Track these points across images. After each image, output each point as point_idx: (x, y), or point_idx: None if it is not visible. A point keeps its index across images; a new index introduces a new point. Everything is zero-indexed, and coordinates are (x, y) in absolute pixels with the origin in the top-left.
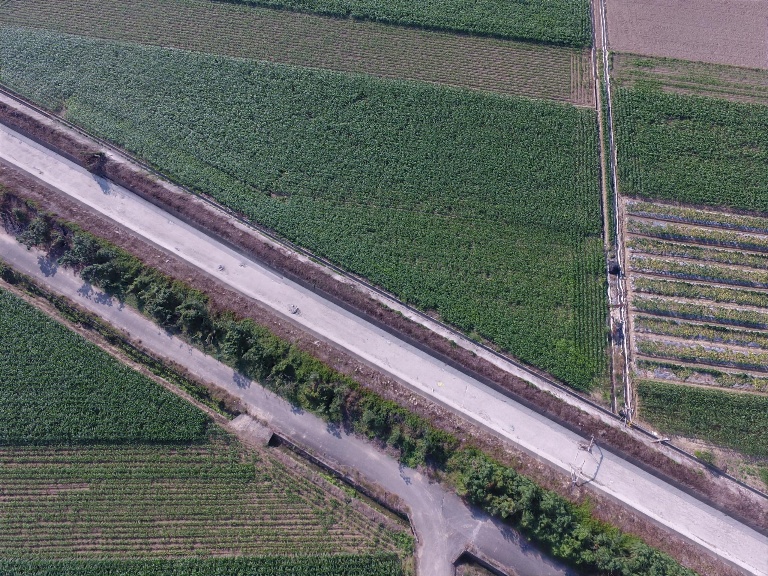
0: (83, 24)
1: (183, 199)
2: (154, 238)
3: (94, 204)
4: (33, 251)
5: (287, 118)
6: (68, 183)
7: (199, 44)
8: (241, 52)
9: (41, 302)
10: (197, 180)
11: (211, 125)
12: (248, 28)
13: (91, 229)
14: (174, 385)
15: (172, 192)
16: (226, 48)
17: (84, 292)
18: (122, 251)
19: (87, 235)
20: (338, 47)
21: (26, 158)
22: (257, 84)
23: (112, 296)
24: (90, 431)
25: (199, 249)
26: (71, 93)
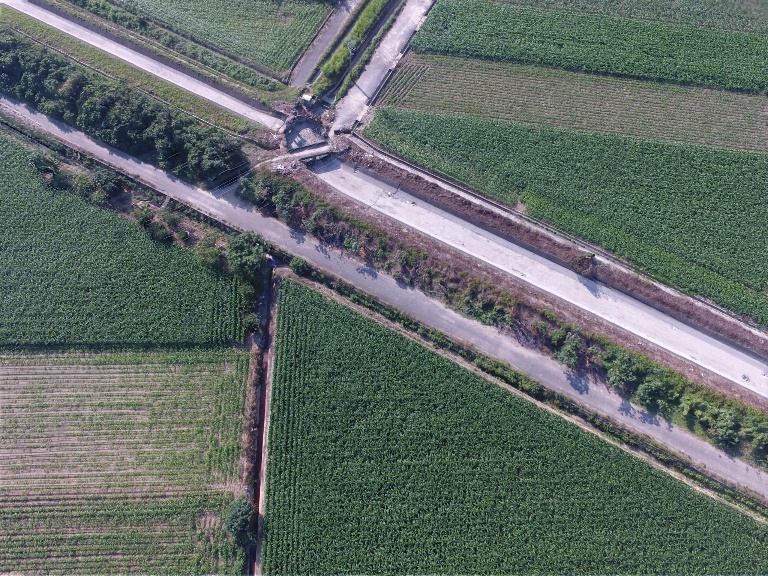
0: (501, 106)
1: (689, 304)
2: (667, 346)
3: (591, 309)
4: (556, 365)
5: (752, 209)
6: (555, 286)
7: (625, 126)
8: (670, 134)
9: (578, 421)
10: (690, 281)
11: (679, 218)
12: (667, 107)
13: (617, 341)
14: (750, 513)
15: (674, 296)
16: (653, 130)
17: (626, 411)
18: (662, 366)
19: (622, 350)
20: (763, 126)
21: (501, 258)
22: (706, 171)
23: (656, 415)
24: (704, 572)
25: (715, 357)
26: (524, 185)
